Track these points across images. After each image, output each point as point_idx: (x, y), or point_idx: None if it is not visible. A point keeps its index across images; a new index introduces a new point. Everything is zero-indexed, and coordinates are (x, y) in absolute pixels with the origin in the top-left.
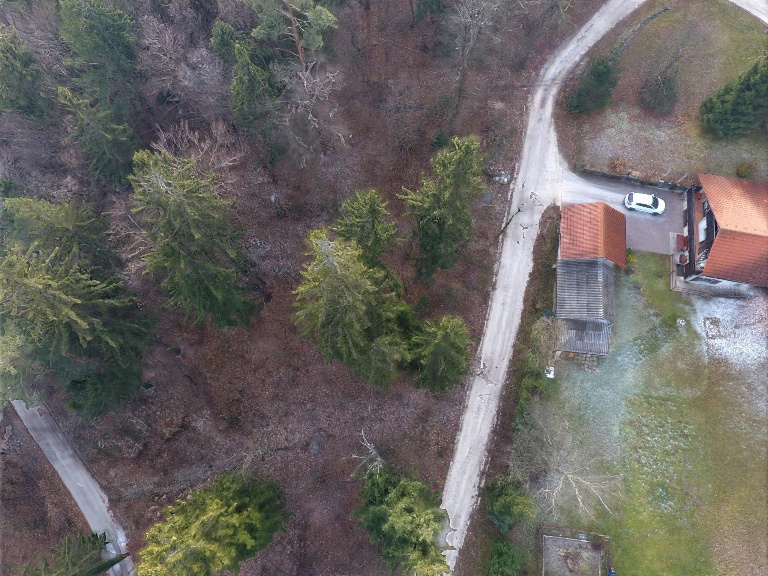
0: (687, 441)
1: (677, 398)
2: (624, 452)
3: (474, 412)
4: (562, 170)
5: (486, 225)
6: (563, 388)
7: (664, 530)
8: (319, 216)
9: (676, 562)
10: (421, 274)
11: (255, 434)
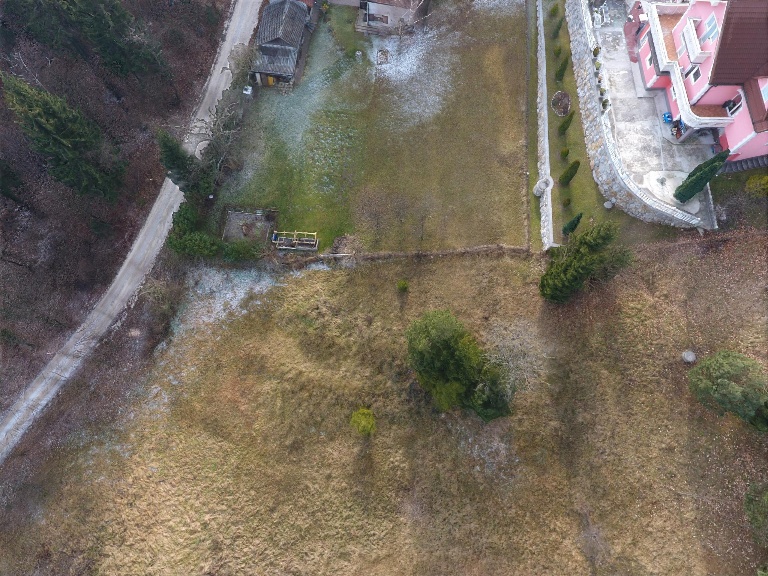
0: (351, 141)
1: (349, 111)
2: (303, 153)
3: (196, 132)
4: None
5: None
6: (263, 108)
7: (323, 205)
8: None
9: (326, 226)
10: None
11: (42, 178)
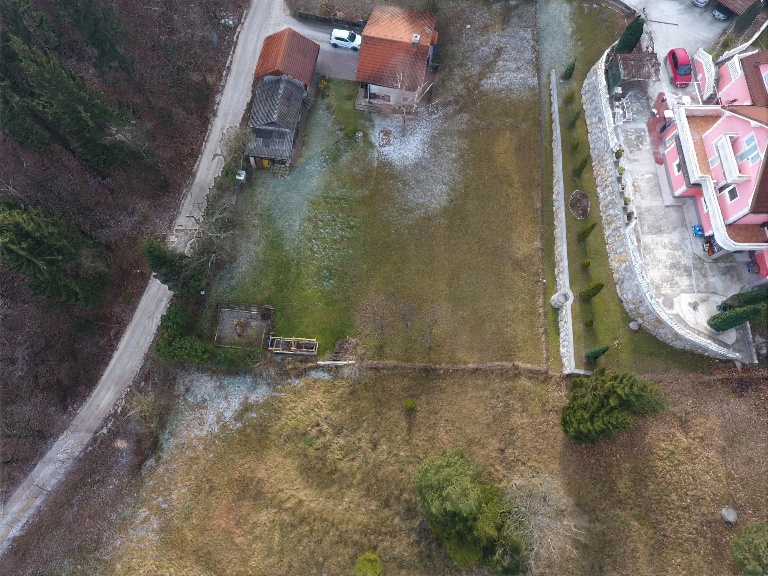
0: (352, 231)
1: (350, 197)
2: (301, 243)
3: (186, 217)
4: (284, 16)
5: (213, 62)
6: (257, 192)
7: (323, 303)
8: (72, 57)
9: (326, 326)
10: (103, 72)
11: None
